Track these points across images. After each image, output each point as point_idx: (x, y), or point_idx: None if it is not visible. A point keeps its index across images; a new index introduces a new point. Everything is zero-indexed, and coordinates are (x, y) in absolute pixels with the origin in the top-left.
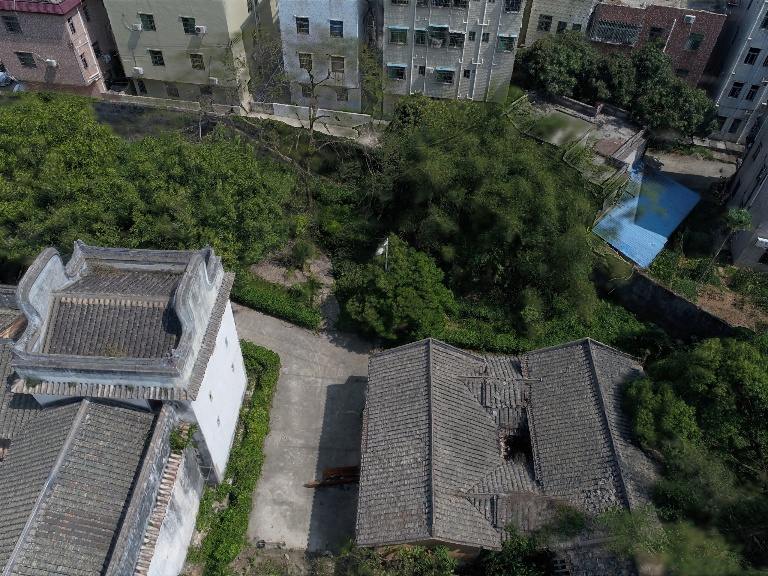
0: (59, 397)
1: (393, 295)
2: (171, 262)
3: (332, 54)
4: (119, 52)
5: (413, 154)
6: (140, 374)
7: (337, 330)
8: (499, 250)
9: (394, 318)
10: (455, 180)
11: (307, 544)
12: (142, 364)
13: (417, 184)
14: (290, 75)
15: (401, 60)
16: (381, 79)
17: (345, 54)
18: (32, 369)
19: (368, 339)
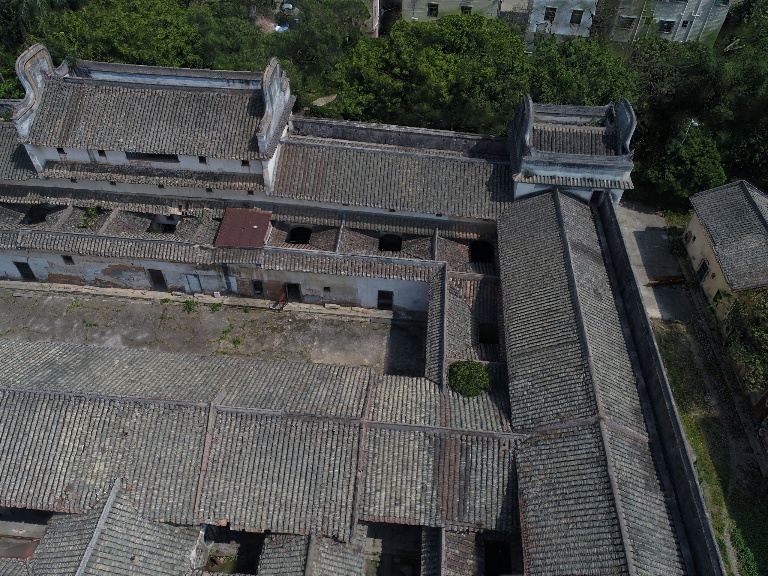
0: (533, 190)
1: (690, 163)
2: (581, 115)
3: (574, 8)
4: (402, 5)
5: (684, 70)
6: (605, 168)
7: (625, 199)
8: (760, 137)
9: (694, 178)
10: (738, 80)
11: (661, 315)
12: (610, 160)
13: (683, 94)
14: (533, 26)
15: (633, 12)
16: (606, 30)
17: (585, 8)
18: (534, 164)
19: (652, 205)
